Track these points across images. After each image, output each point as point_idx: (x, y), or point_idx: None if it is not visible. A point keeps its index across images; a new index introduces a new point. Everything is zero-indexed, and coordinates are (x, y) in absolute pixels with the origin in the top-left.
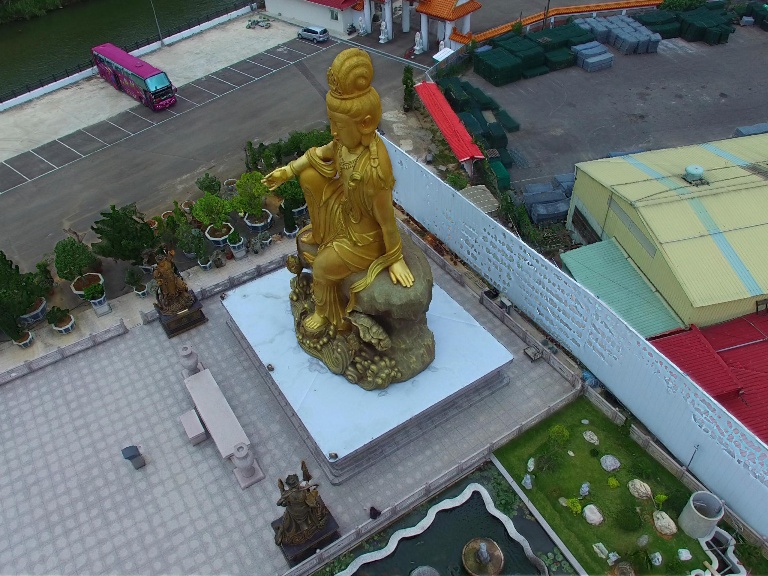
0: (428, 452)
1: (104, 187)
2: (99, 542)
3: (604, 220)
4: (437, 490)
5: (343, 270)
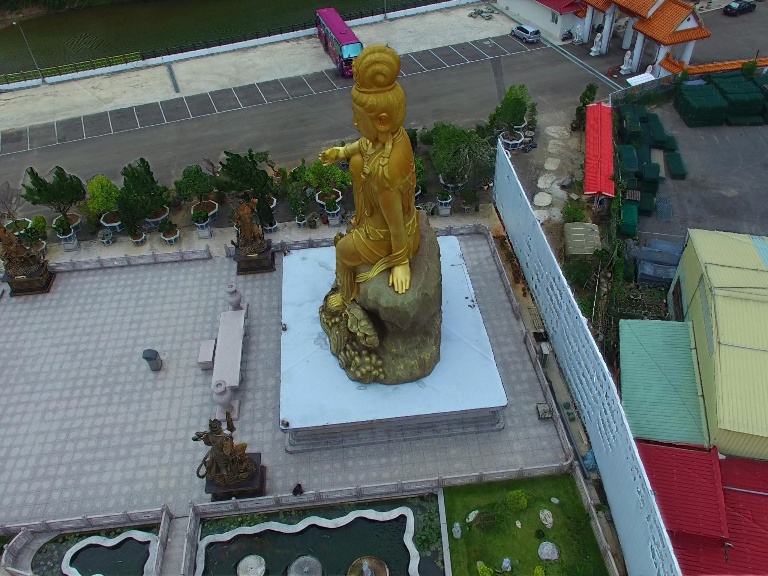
0: (384, 460)
1: (267, 133)
2: (96, 415)
3: (690, 299)
4: (370, 497)
5: (356, 258)
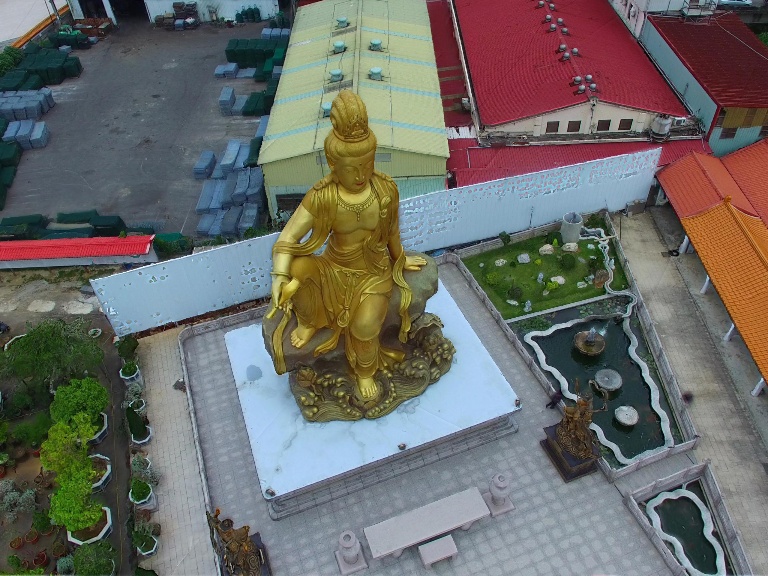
0: None
1: None
2: None
3: None
4: None
5: (386, 304)
